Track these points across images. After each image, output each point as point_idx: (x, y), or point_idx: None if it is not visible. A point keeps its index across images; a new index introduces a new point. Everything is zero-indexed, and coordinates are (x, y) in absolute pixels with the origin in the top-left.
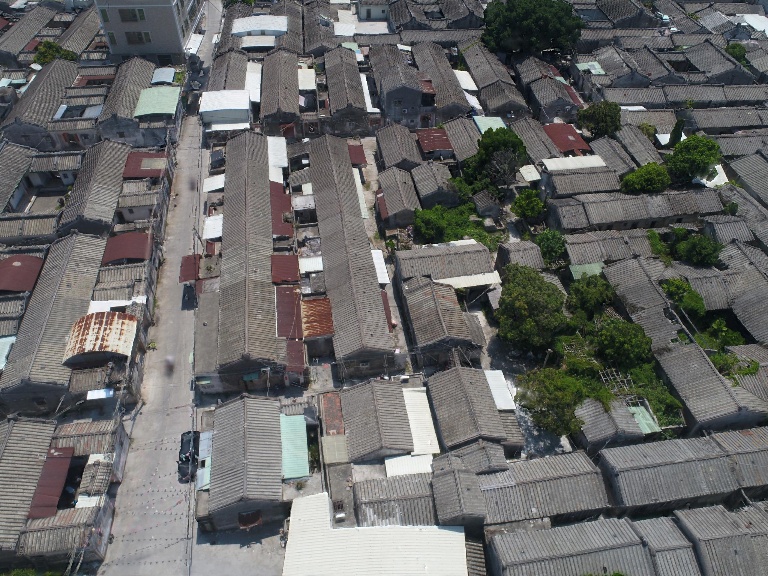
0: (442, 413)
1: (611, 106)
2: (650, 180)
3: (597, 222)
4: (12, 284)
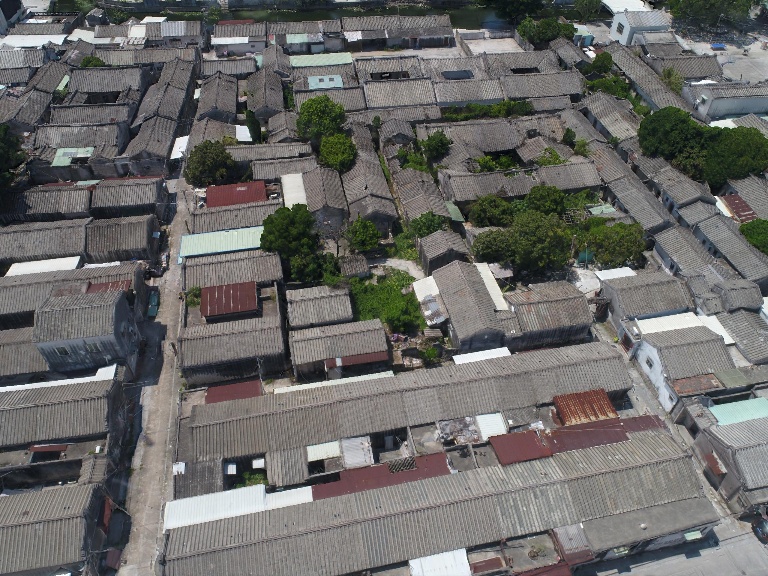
0: (659, 307)
1: (211, 145)
2: (350, 146)
3: (390, 194)
4: None
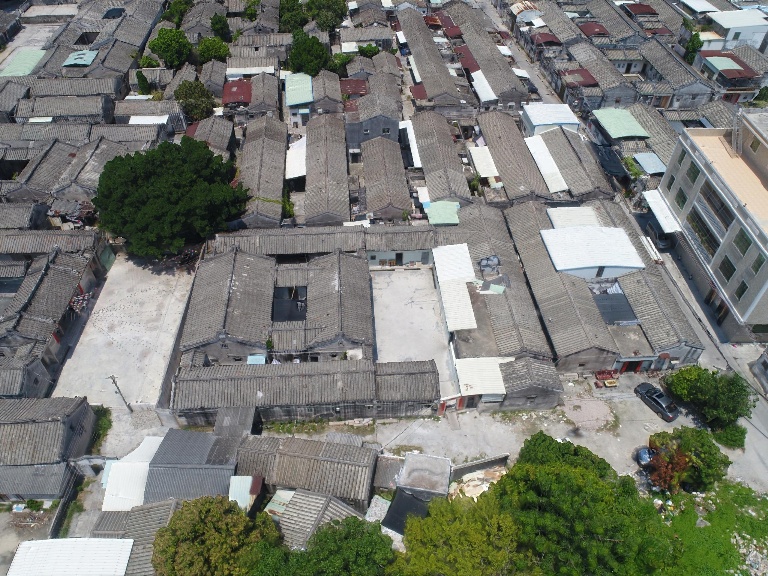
0: (378, 0)
1: None
2: None
3: None
4: (589, 24)
